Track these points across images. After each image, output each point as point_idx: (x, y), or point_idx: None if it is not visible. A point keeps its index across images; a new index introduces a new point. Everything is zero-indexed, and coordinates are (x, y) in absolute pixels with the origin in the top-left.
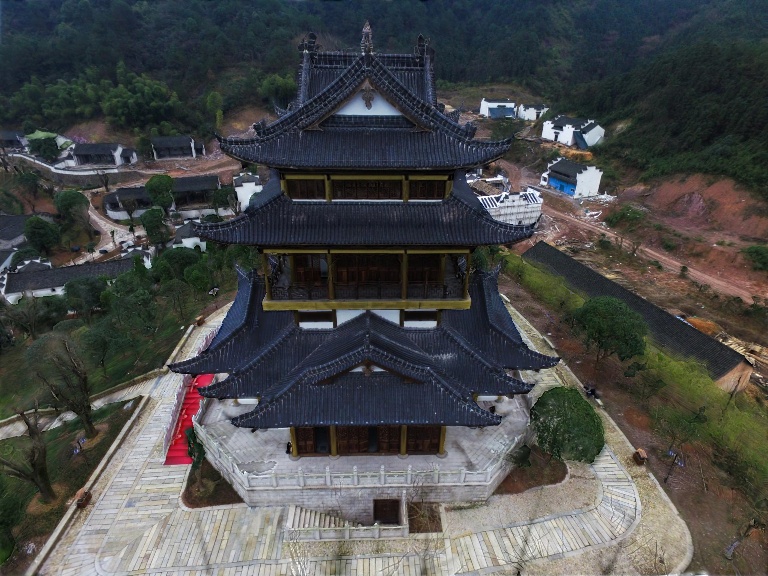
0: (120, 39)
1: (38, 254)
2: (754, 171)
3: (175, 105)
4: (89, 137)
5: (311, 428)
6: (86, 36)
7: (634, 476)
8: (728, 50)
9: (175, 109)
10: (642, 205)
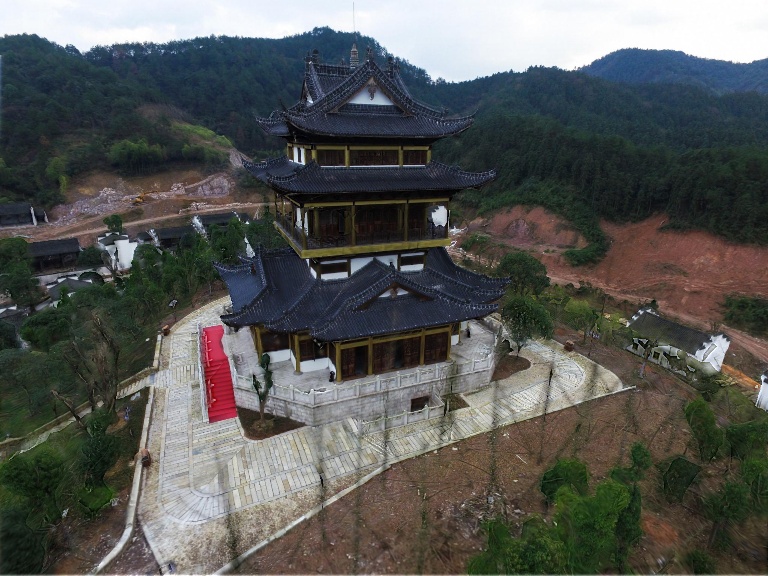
0: None
1: None
2: (554, 199)
3: (3, 171)
4: None
5: (353, 350)
6: None
7: (570, 357)
8: (515, 119)
9: (3, 176)
10: (485, 233)
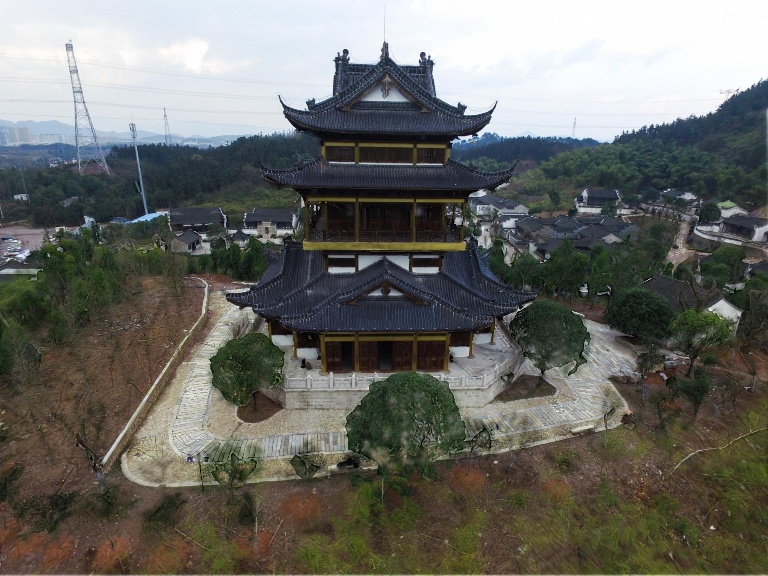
0: None
1: None
2: None
3: None
4: None
5: None
6: None
7: None
8: None
9: None
10: None
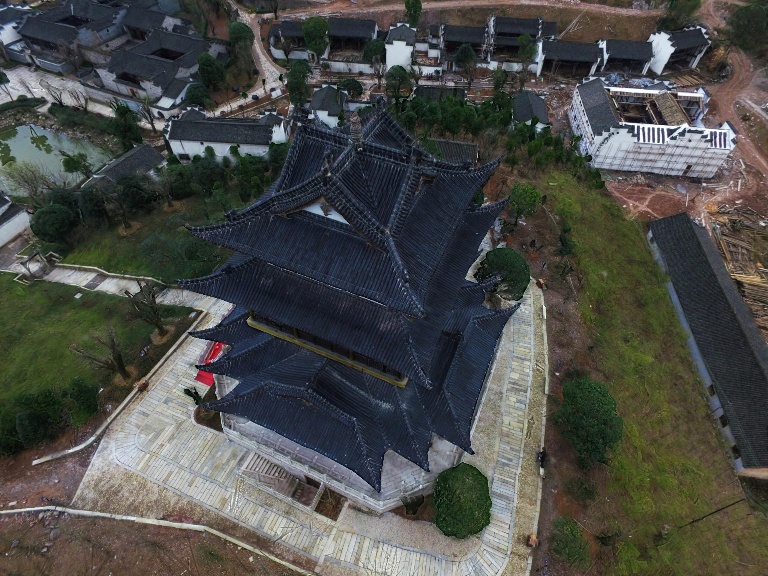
0: None
1: (205, 90)
2: None
3: None
4: None
5: None
6: None
7: (514, 552)
8: None
9: None
10: None
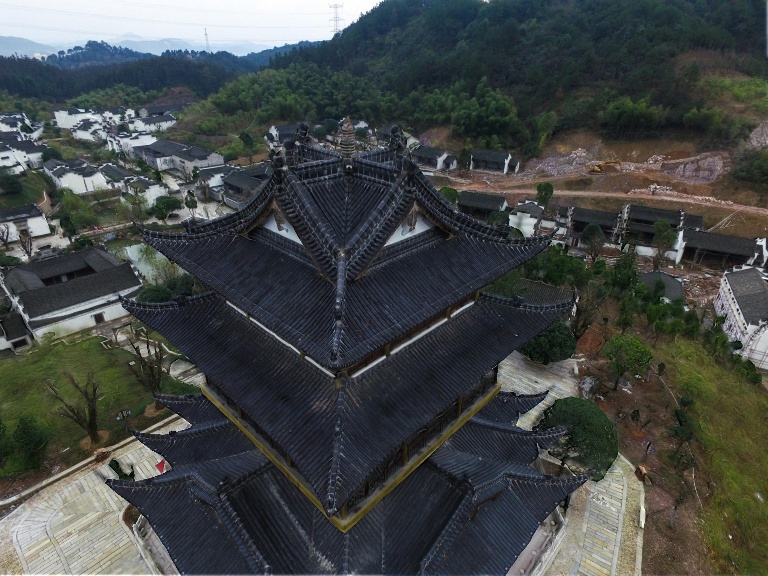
0: (495, 55)
1: None
2: None
3: (511, 121)
4: (433, 140)
5: None
6: (471, 52)
7: None
8: None
9: (509, 125)
10: None
